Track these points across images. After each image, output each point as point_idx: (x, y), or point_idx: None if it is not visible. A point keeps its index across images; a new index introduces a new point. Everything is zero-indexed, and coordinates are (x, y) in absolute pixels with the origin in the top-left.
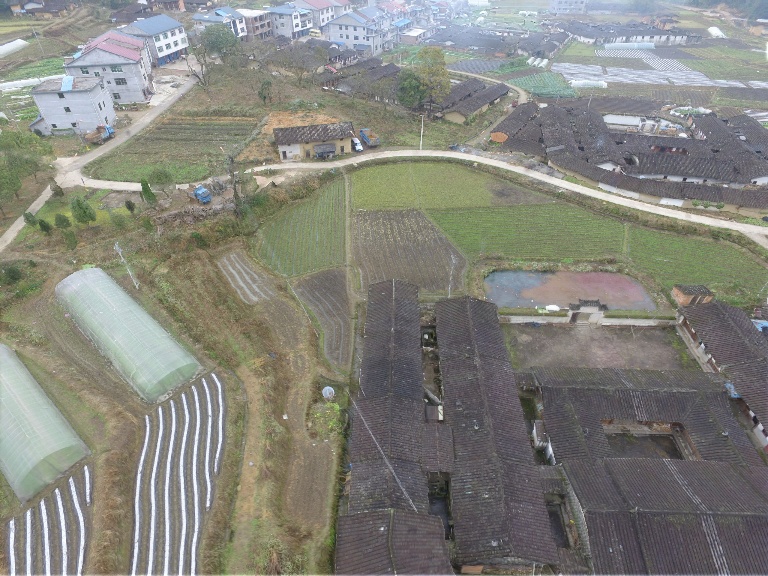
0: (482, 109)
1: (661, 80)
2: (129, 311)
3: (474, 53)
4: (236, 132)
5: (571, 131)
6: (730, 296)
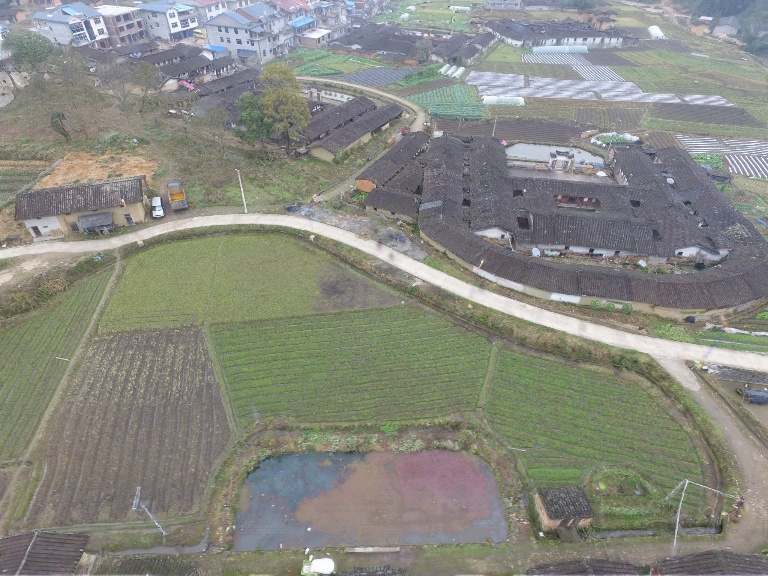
0: (361, 140)
1: (588, 94)
2: None
3: (381, 59)
4: (3, 187)
5: (460, 175)
6: (622, 509)
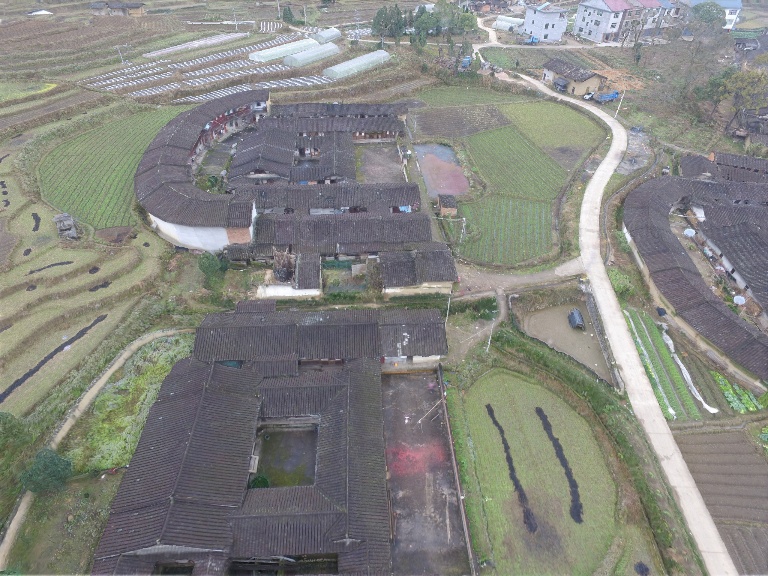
0: None
1: None
2: (362, 60)
3: None
4: None
5: None
6: None
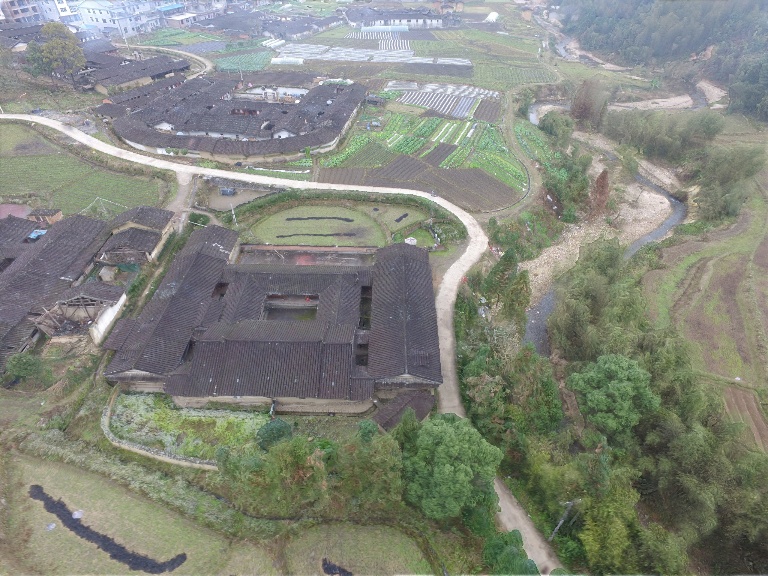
0: (140, 82)
1: (363, 58)
2: None
3: (222, 35)
4: None
5: (180, 98)
6: None
